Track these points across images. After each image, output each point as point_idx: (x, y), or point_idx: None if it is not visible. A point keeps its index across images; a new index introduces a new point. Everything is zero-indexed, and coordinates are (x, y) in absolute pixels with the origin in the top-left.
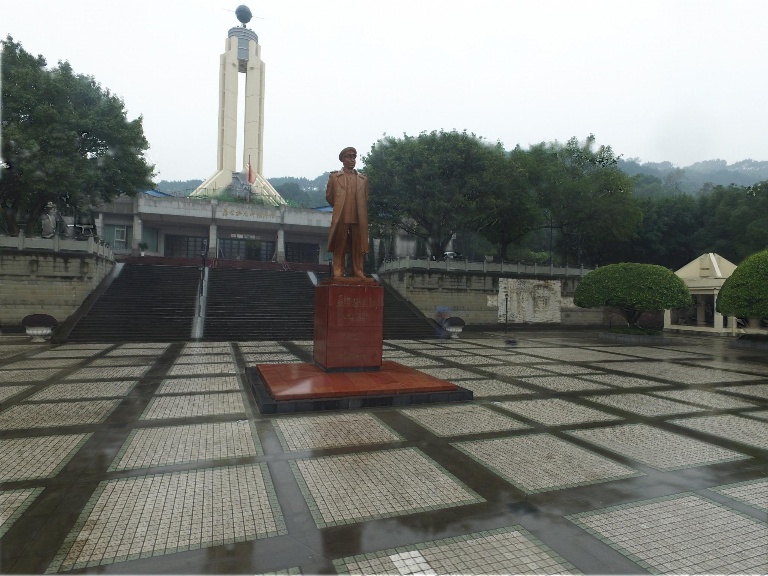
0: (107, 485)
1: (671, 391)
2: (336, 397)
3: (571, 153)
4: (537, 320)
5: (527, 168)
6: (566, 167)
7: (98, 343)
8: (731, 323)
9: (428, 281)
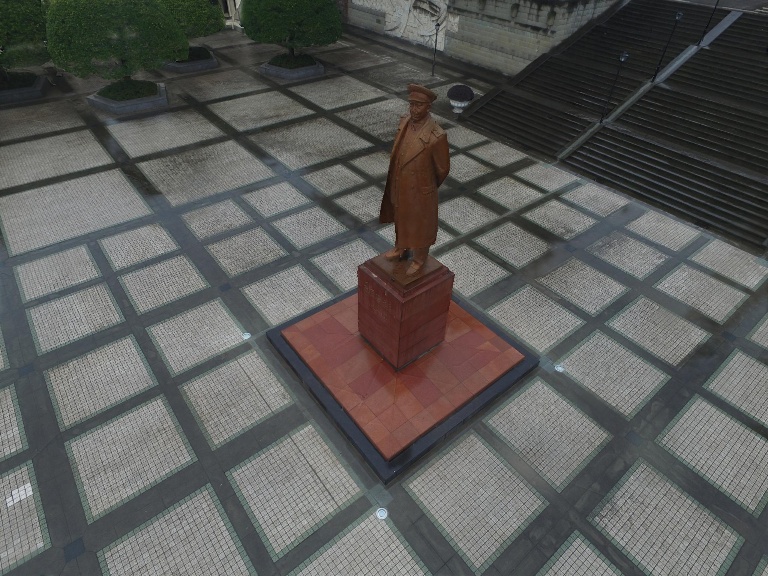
0: (126, 339)
1: None
2: (308, 367)
3: None
4: None
5: None
6: None
7: (483, 131)
8: None
9: None
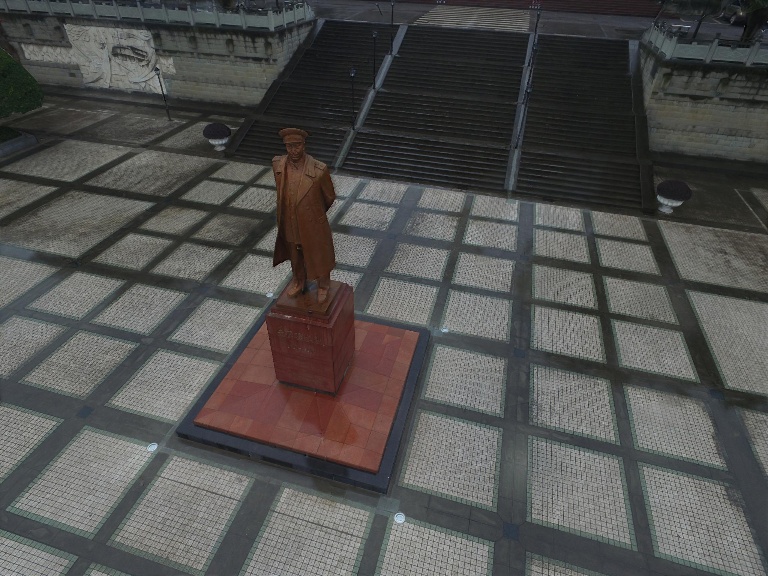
0: None
1: None
2: (246, 438)
3: None
4: None
5: None
6: None
7: (256, 161)
8: None
9: (697, 84)
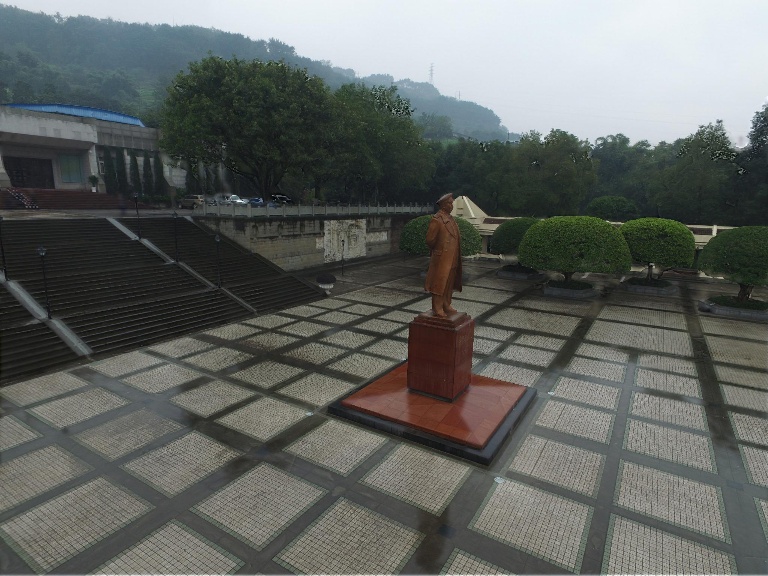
0: None
1: (580, 349)
2: (498, 428)
3: (374, 98)
4: (351, 256)
5: None
6: None
7: None
8: None
9: (269, 229)
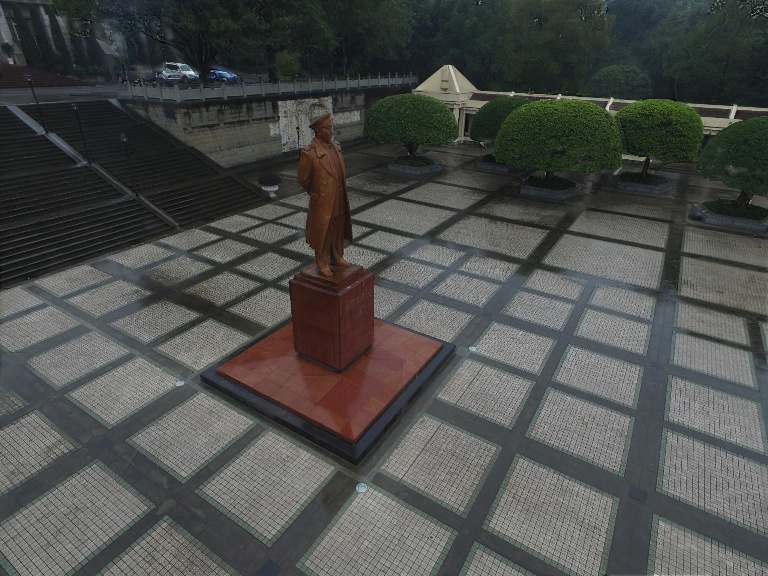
0: None
1: (531, 278)
2: (387, 408)
3: None
4: None
5: None
6: None
7: None
8: (461, 132)
9: (207, 116)
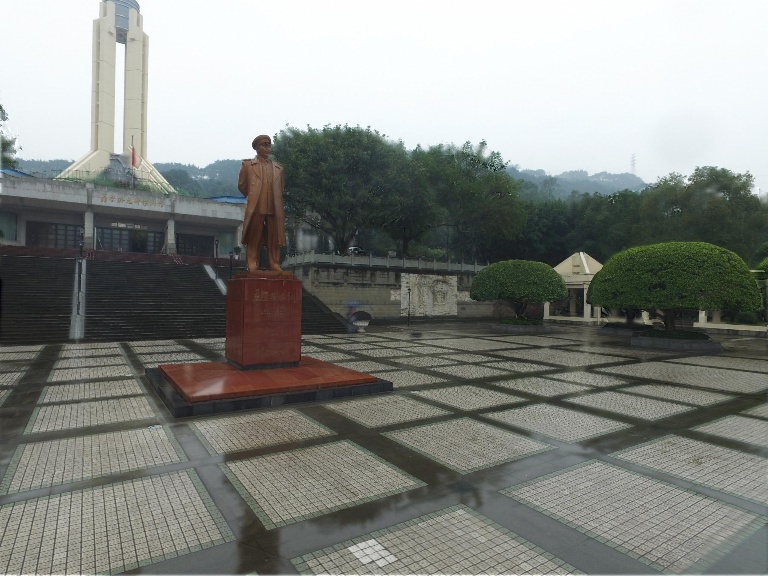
0: (0, 511)
1: (561, 374)
2: (256, 395)
3: (466, 156)
4: (436, 313)
5: (428, 168)
6: (462, 169)
7: None
8: (596, 313)
9: (333, 276)
